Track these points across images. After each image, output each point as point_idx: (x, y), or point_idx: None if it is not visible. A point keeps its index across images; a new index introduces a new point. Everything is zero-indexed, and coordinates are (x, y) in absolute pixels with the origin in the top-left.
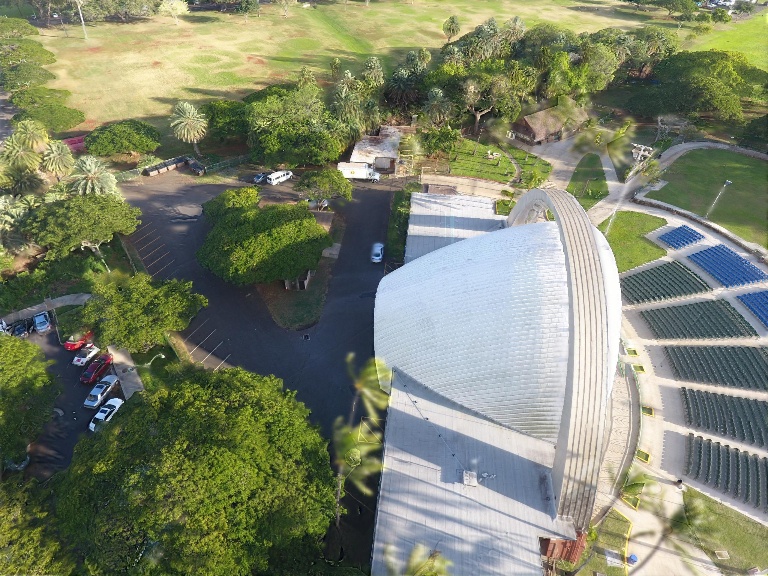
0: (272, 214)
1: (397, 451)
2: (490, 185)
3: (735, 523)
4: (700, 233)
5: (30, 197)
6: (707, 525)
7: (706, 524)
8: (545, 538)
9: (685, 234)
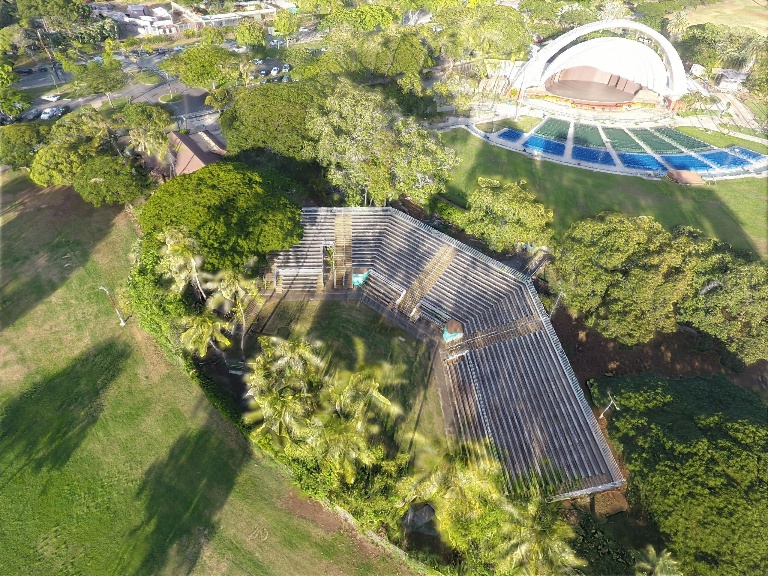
0: (613, 33)
1: (522, 62)
2: (746, 112)
3: (534, 122)
4: (764, 162)
5: (584, 8)
6: (530, 118)
7: (531, 118)
8: (507, 78)
9: (753, 154)
